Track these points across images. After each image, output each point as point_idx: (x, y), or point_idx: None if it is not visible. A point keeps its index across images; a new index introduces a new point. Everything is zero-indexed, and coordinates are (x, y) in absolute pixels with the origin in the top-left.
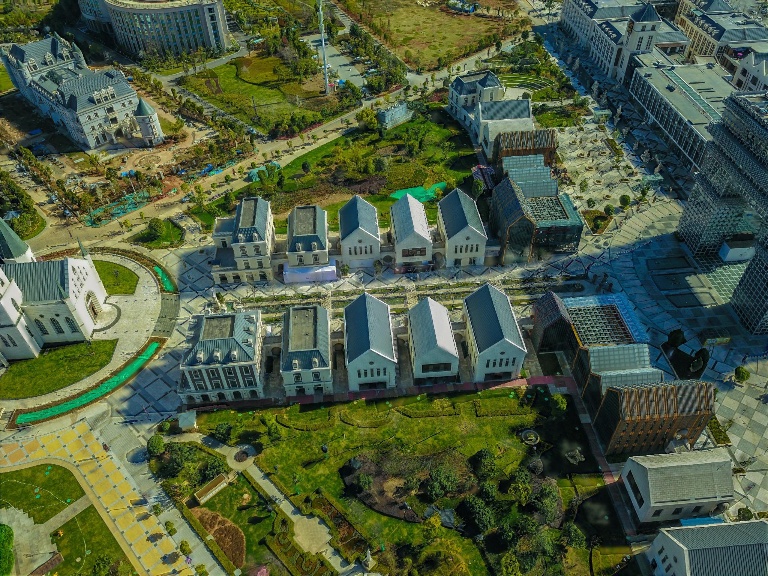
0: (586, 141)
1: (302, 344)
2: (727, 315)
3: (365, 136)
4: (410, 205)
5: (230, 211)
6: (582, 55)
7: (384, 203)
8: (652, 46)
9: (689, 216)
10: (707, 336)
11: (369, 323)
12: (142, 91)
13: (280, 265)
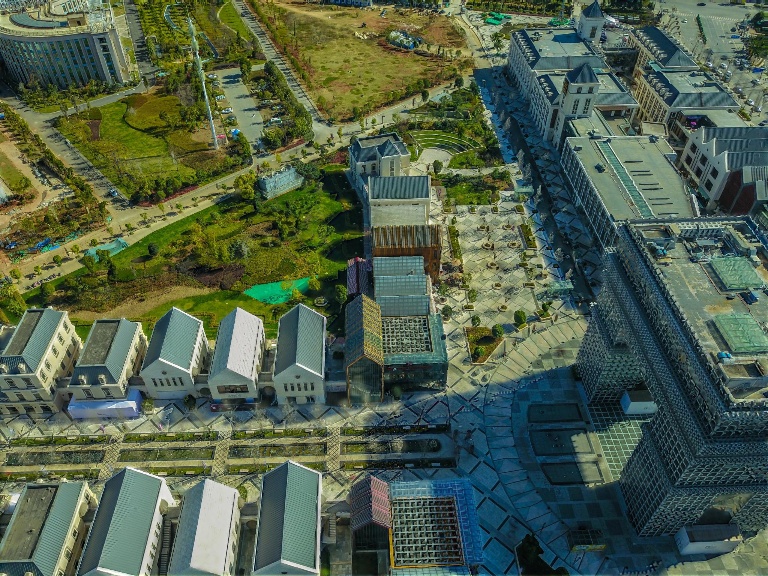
0: (497, 226)
1: (18, 548)
2: (612, 501)
3: (240, 207)
4: (236, 326)
5: (46, 305)
6: (521, 109)
7: (233, 303)
8: (590, 110)
9: (586, 353)
10: (575, 541)
11: (113, 520)
12: (8, 133)
13: (70, 393)
